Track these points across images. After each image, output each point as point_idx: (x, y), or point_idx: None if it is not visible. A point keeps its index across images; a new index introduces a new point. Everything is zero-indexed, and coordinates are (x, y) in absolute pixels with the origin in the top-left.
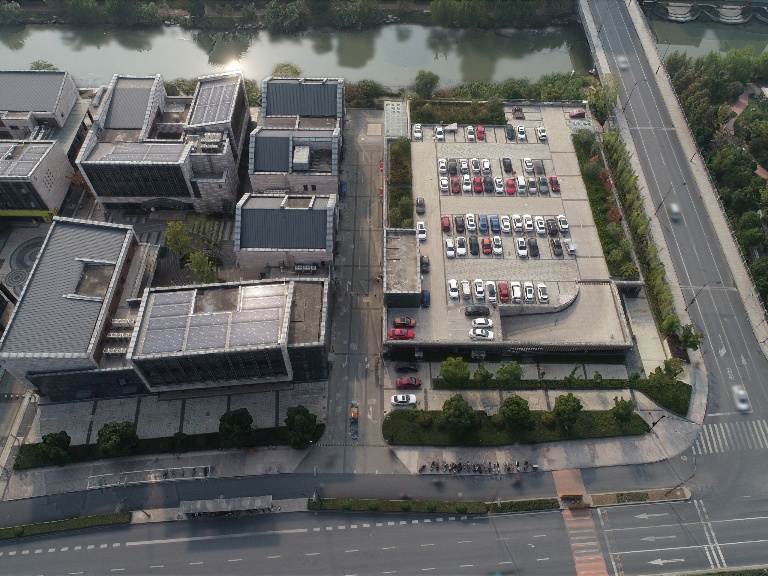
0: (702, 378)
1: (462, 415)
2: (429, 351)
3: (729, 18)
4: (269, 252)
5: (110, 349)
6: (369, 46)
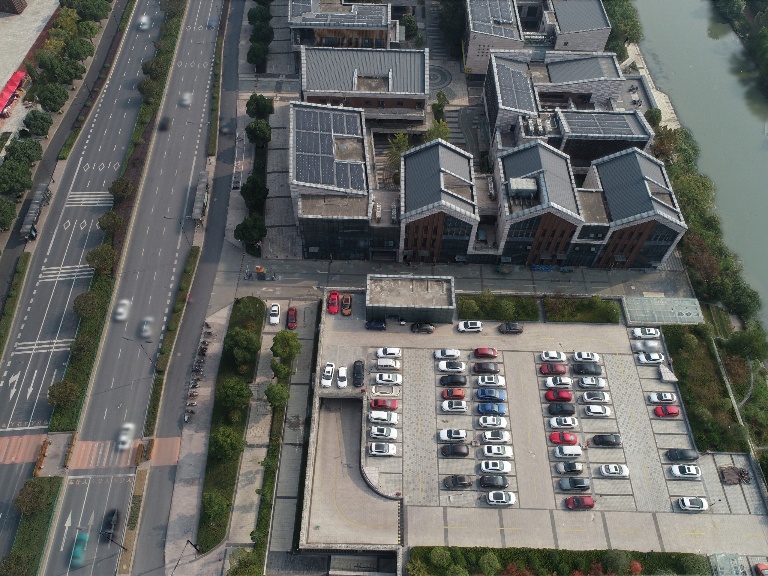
0: None
1: (234, 341)
2: None
3: None
4: None
5: None
6: None
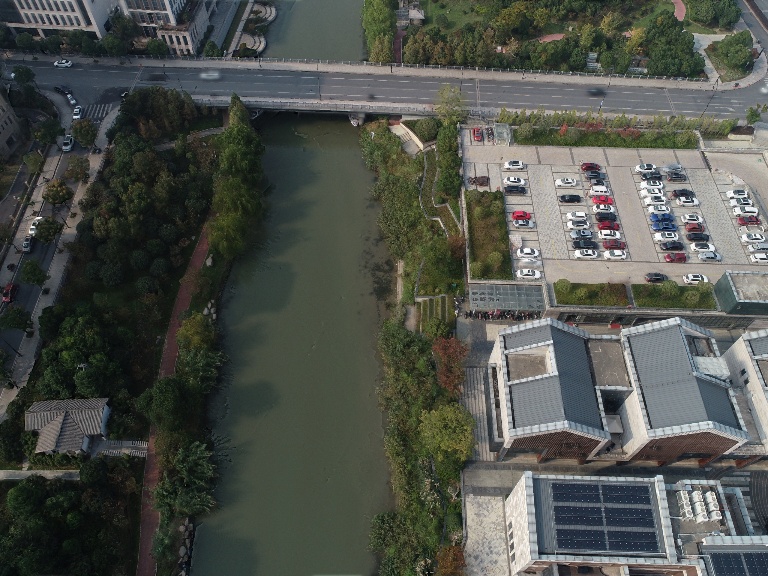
0: (762, 124)
1: None
2: None
3: (268, 14)
4: None
5: None
6: (275, 345)
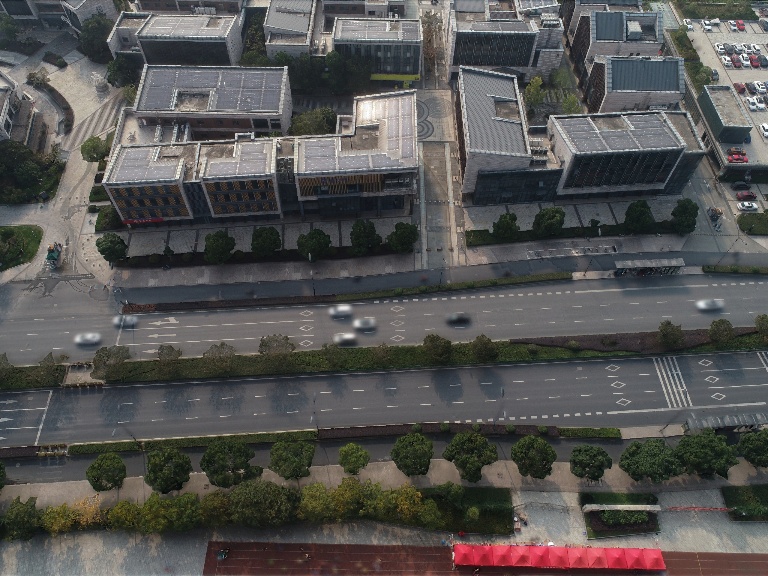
0: None
1: None
2: (756, 175)
3: None
4: (634, 93)
5: (535, 157)
6: None
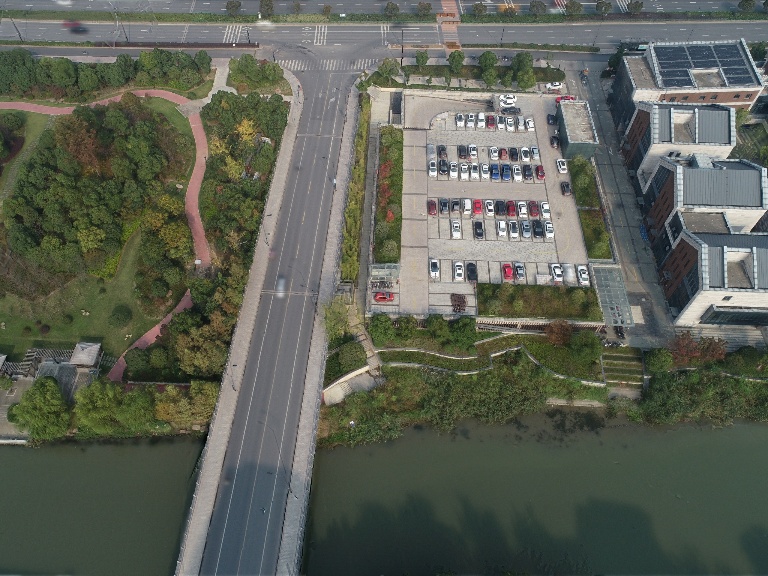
0: (355, 87)
1: None
2: None
3: None
4: None
5: (761, 70)
6: (694, 541)
